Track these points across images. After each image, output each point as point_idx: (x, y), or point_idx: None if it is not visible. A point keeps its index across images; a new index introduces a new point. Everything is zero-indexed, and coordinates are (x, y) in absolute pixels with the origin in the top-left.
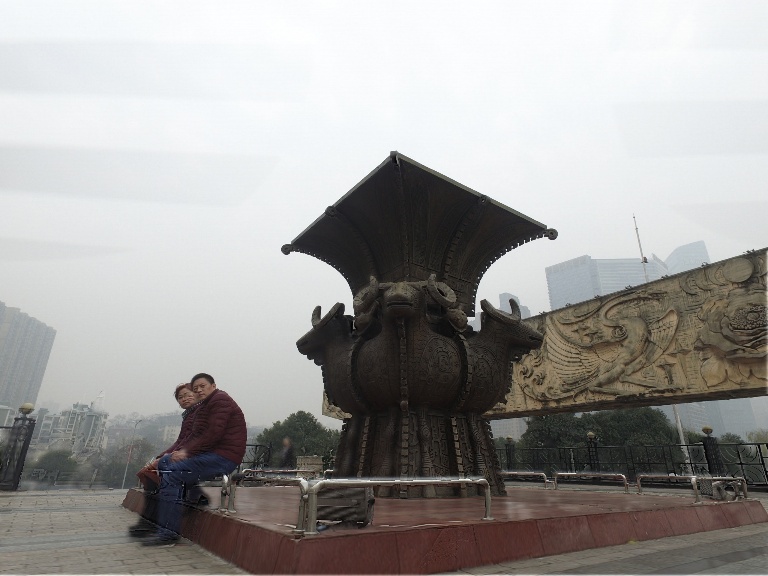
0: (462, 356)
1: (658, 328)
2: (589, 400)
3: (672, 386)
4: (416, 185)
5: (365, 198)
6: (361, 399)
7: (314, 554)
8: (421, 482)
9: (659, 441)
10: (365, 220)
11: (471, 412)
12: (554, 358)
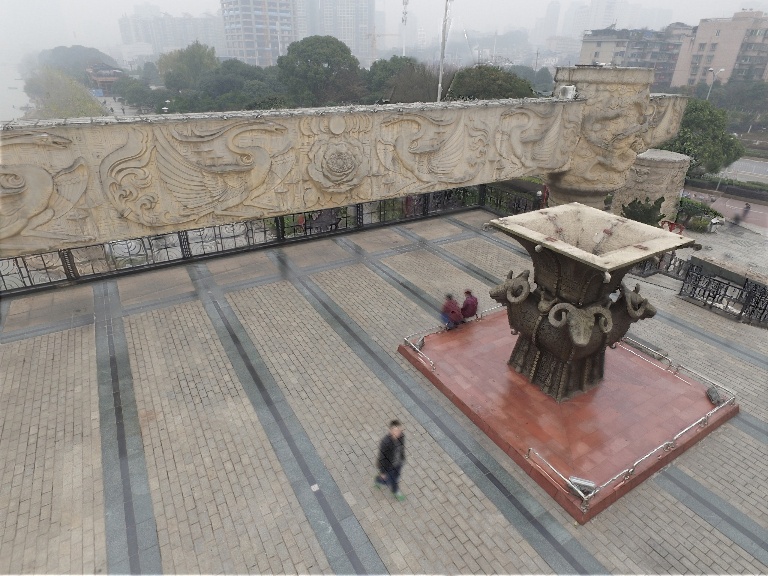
0: None
1: None
2: None
3: None
4: None
5: None
6: None
7: (400, 348)
8: None
9: None
10: None
11: None
12: None
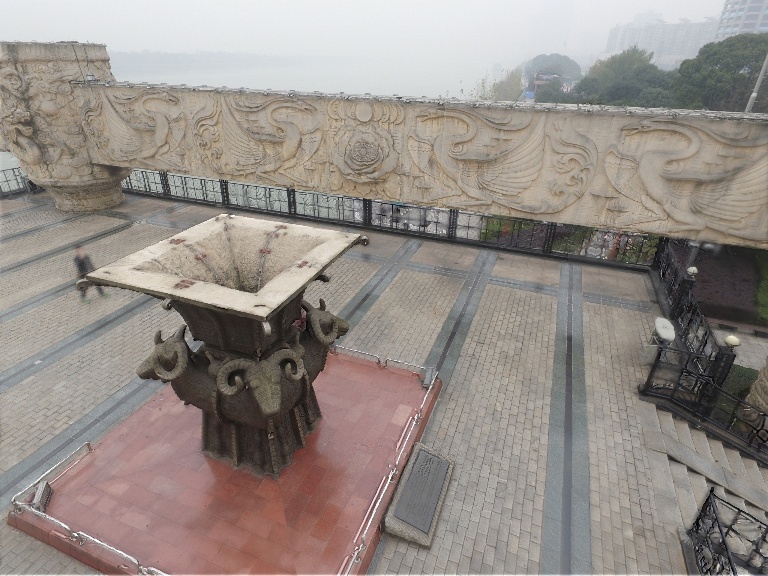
0: None
1: None
2: None
3: None
4: None
5: None
6: None
7: None
8: None
9: None
10: None
11: None
12: None
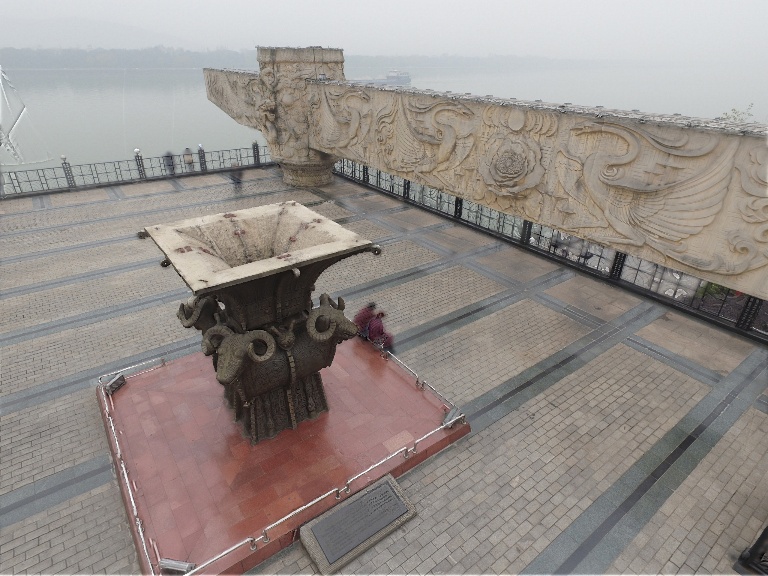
0: None
1: None
2: None
3: None
4: None
5: None
6: None
7: None
8: None
9: None
10: None
11: None
12: None
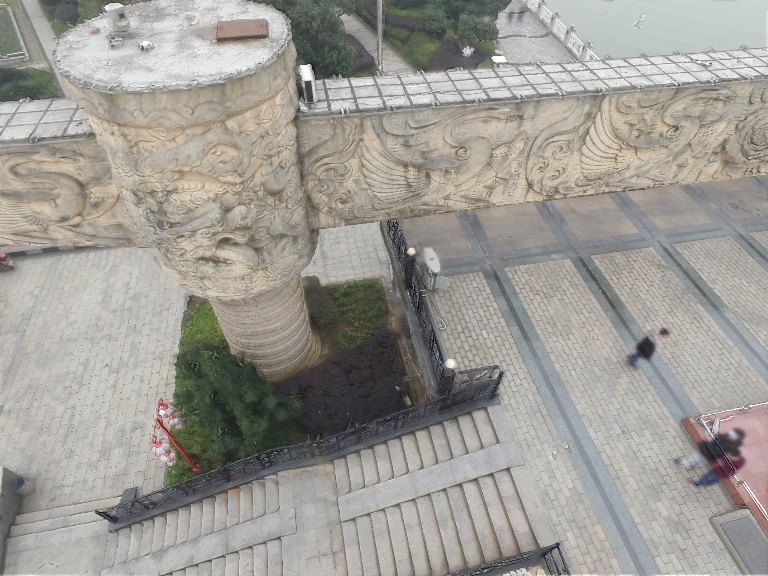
0: None
1: (705, 133)
2: (599, 192)
3: (675, 181)
4: None
5: None
6: None
7: None
8: None
9: (326, 10)
10: None
11: None
12: (588, 153)
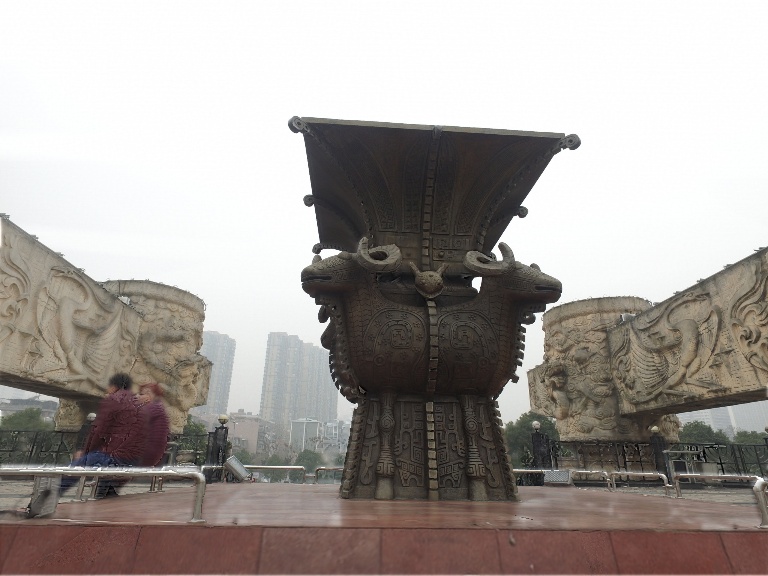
0: (428, 327)
1: None
2: None
3: None
4: (346, 144)
5: (322, 176)
6: (343, 389)
7: None
8: (89, 473)
9: None
10: (338, 199)
11: (464, 394)
12: None
